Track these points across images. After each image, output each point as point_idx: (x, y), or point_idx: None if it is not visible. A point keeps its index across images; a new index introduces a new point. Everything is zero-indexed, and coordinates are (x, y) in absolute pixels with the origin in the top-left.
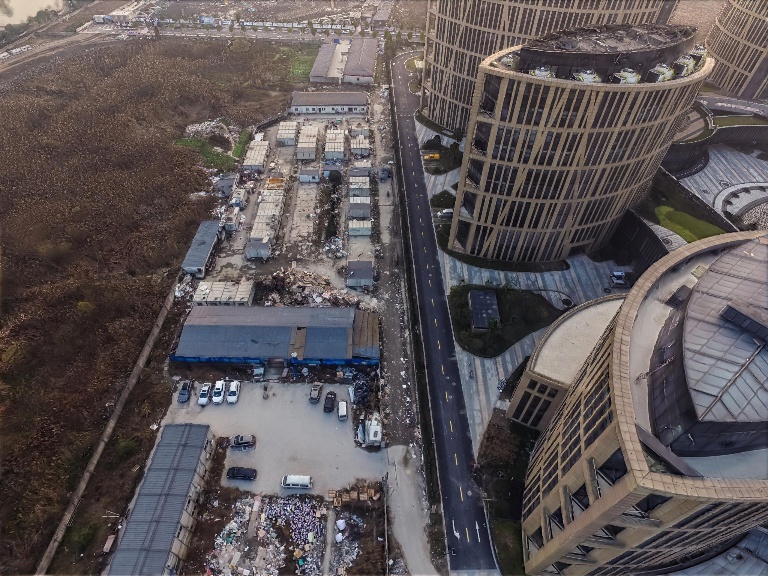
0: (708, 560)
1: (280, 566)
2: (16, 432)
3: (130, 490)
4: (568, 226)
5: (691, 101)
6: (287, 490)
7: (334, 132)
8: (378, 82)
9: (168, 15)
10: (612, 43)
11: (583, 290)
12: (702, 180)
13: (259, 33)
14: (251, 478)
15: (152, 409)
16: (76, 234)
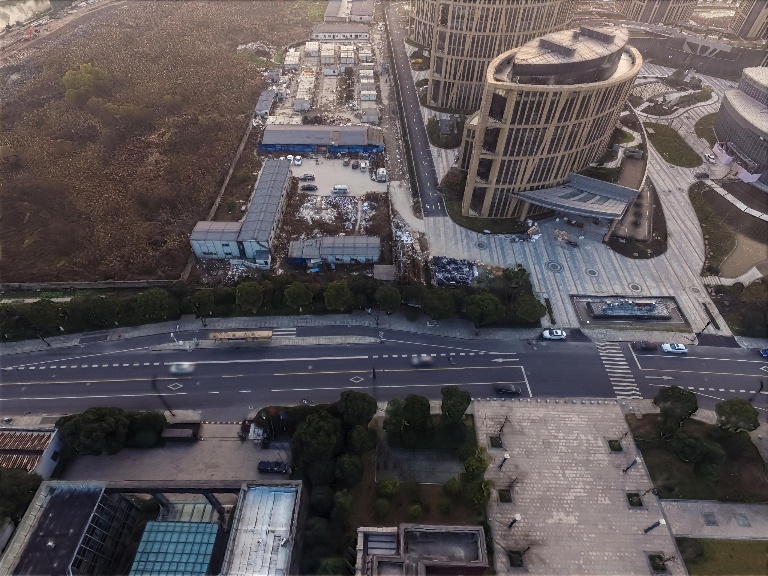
0: (548, 188)
1: (335, 215)
2: None
3: (249, 193)
4: None
5: None
6: (335, 194)
7: (346, 47)
8: (376, 21)
9: None
10: None
11: None
12: None
13: None
14: (315, 188)
15: (252, 166)
16: (183, 93)
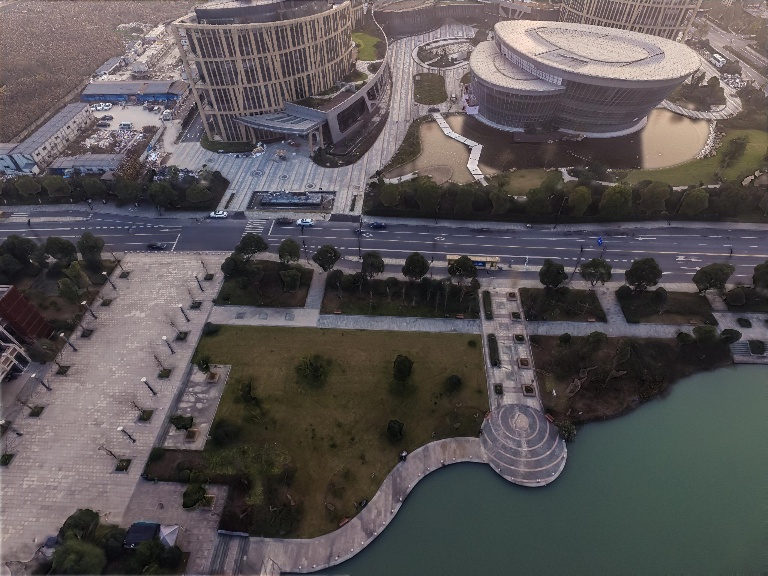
0: (264, 114)
1: (110, 143)
2: None
3: None
4: None
5: None
6: (122, 129)
7: None
8: None
9: None
10: None
11: None
12: (423, 37)
13: None
14: (106, 125)
15: None
16: (41, 59)
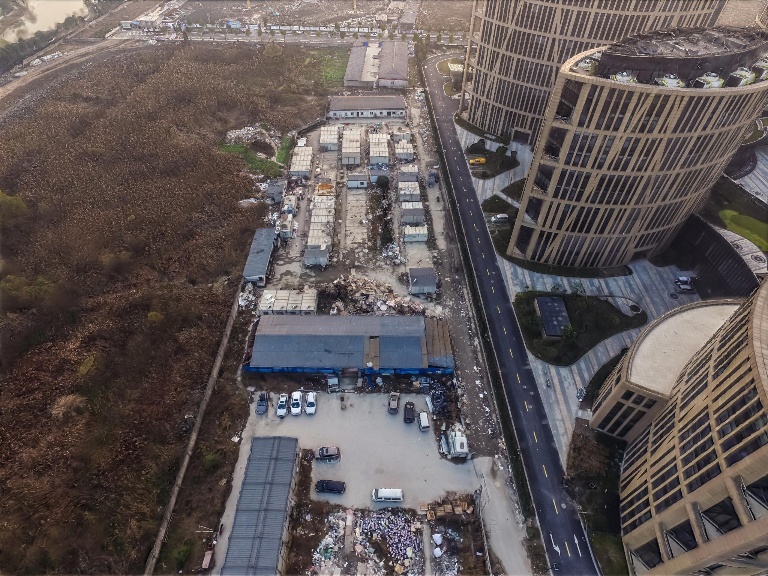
0: None
1: None
2: (98, 445)
3: (220, 504)
4: (634, 231)
5: (766, 104)
6: (378, 503)
7: (376, 137)
8: (413, 85)
9: (193, 20)
10: (688, 47)
11: (649, 296)
12: (753, 182)
13: (287, 37)
14: (341, 491)
15: (232, 421)
16: (135, 243)
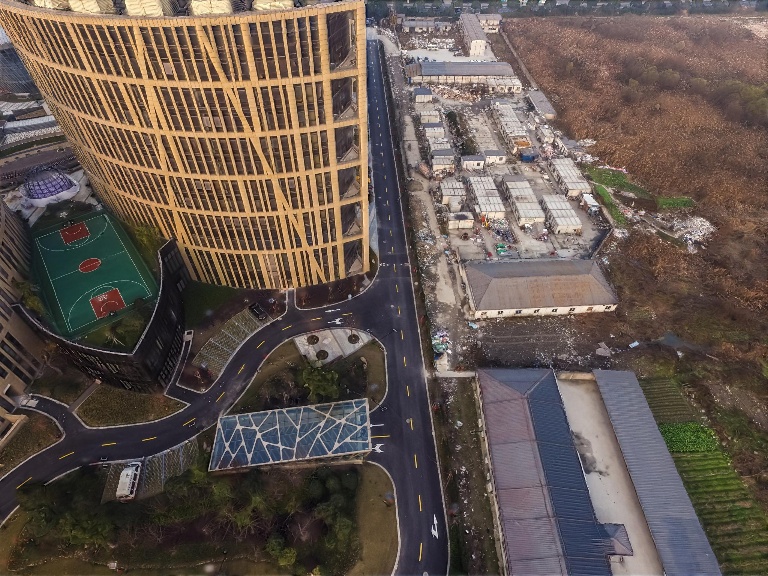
0: None
1: None
2: None
3: None
4: None
5: None
6: None
7: (494, 206)
8: None
9: None
10: None
11: None
12: None
13: None
14: None
15: None
16: None
